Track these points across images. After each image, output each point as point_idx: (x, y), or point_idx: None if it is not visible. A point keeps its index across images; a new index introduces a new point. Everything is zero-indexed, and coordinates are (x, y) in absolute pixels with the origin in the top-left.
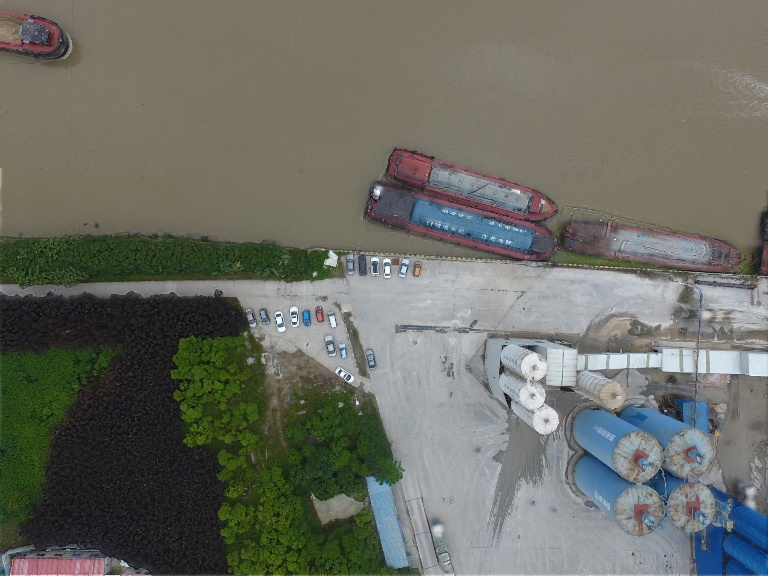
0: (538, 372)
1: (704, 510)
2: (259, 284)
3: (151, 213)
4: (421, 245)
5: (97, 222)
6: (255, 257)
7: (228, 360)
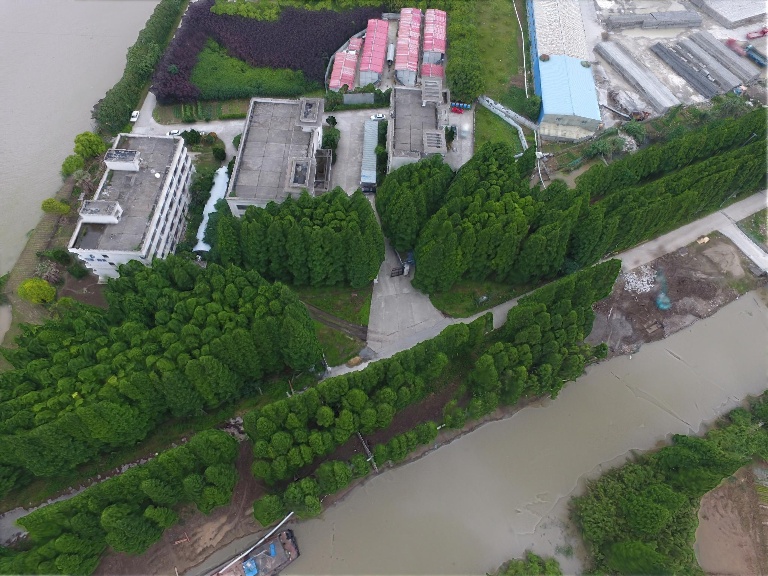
0: None
1: None
2: (193, 0)
3: (132, 39)
4: None
5: None
6: None
7: None
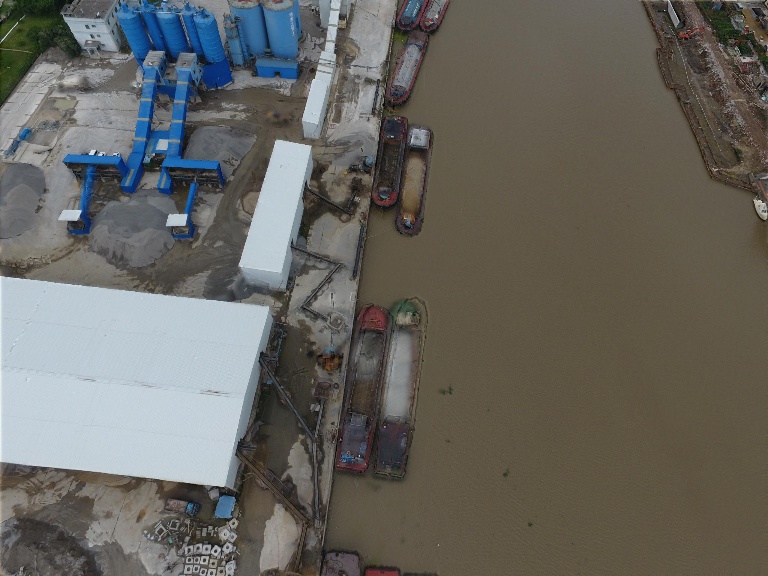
0: None
1: (242, 3)
2: None
3: None
4: None
5: None
6: None
7: None
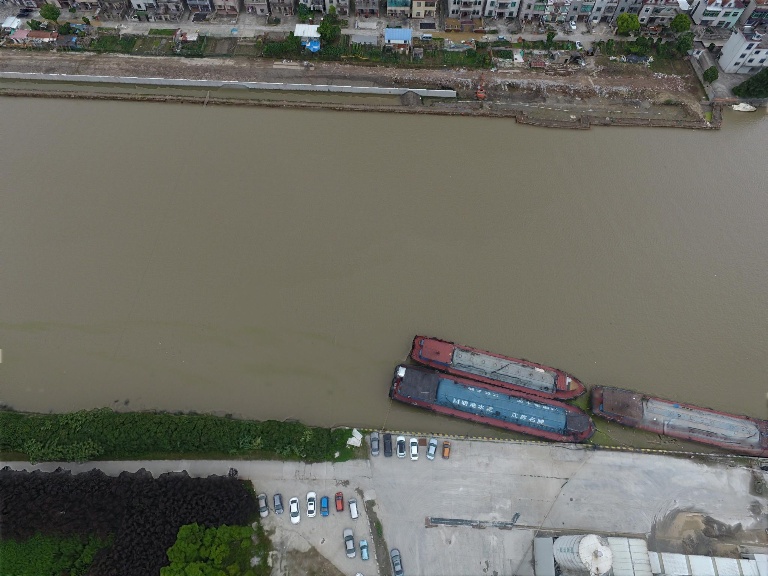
0: (602, 561)
1: None
2: (277, 465)
3: (182, 391)
4: (449, 425)
5: (128, 399)
6: (277, 432)
7: (229, 559)
